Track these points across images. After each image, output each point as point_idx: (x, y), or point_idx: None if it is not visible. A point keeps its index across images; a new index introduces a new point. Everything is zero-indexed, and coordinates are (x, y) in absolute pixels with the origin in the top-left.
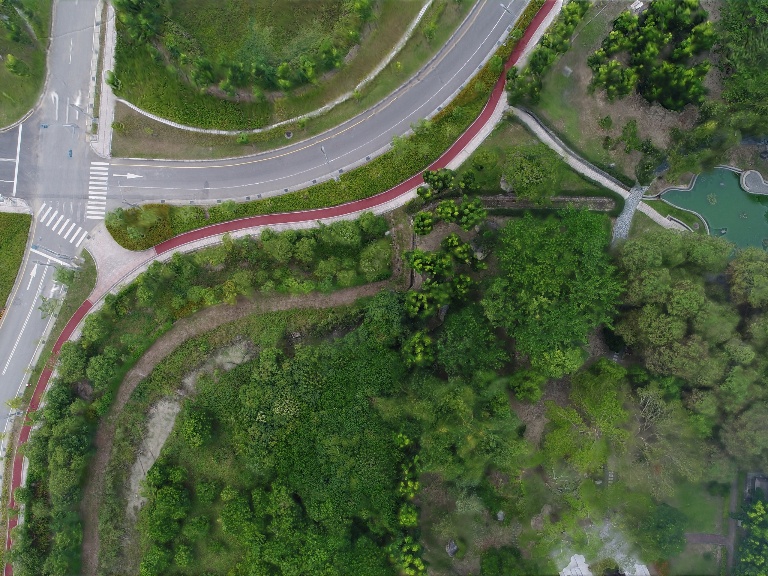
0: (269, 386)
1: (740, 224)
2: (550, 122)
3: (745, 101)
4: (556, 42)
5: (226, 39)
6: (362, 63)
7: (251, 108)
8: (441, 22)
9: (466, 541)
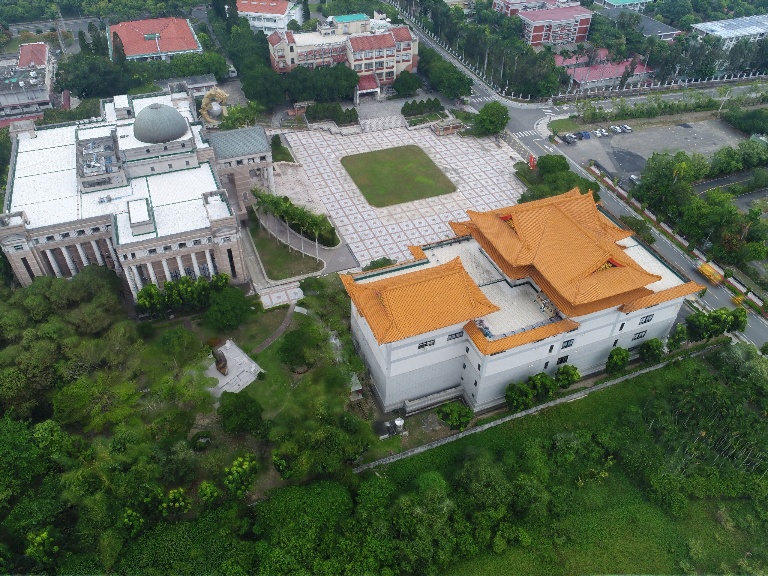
0: None
1: None
2: None
3: None
4: None
5: None
6: None
7: None
8: None
9: None
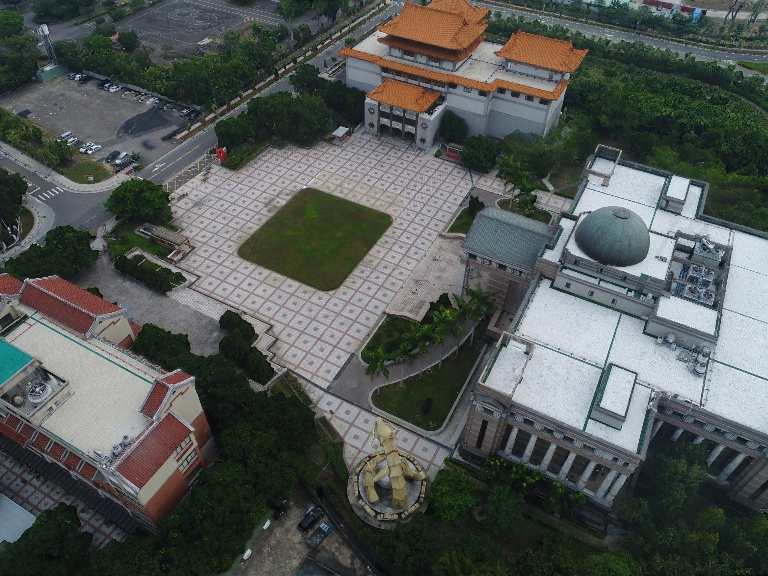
0: None
1: None
2: None
3: None
4: None
5: None
6: None
7: None
8: None
9: None
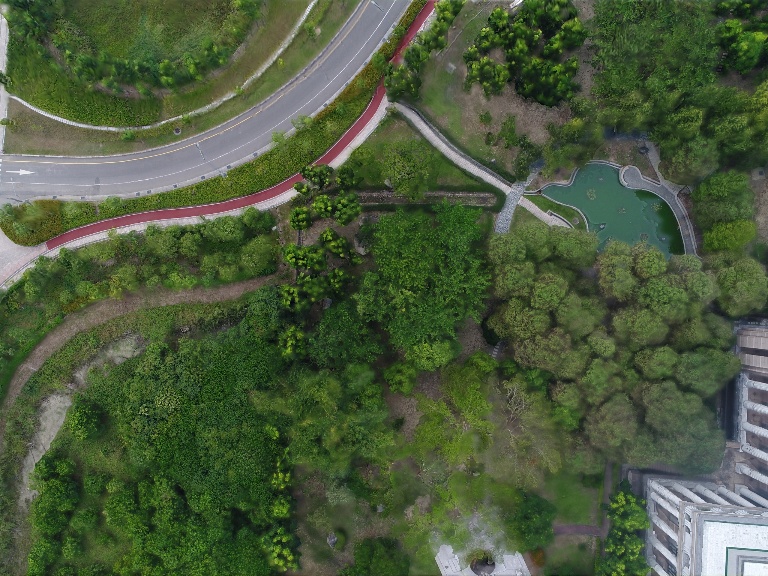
0: (152, 380)
1: (621, 219)
2: (434, 118)
3: (612, 97)
4: (429, 39)
5: (118, 36)
6: (250, 60)
7: (140, 105)
8: (327, 19)
9: (347, 532)
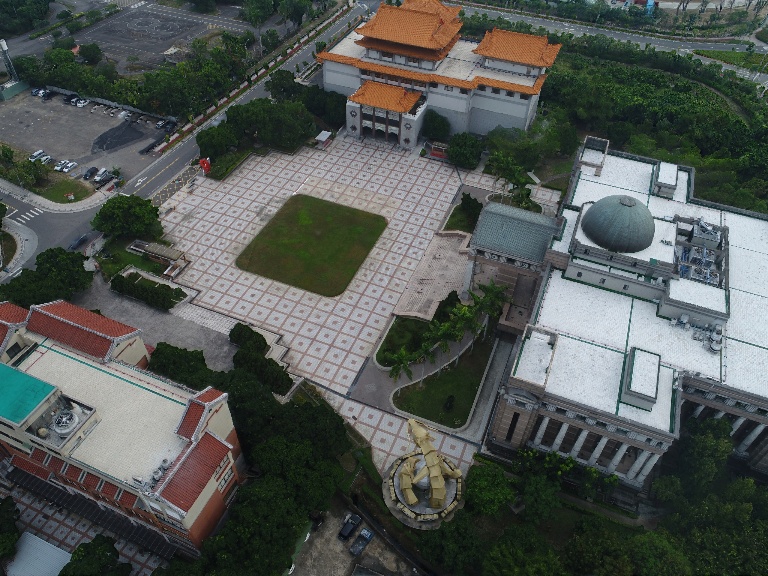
0: None
1: None
2: None
3: None
4: None
5: None
6: None
7: None
8: None
9: None
